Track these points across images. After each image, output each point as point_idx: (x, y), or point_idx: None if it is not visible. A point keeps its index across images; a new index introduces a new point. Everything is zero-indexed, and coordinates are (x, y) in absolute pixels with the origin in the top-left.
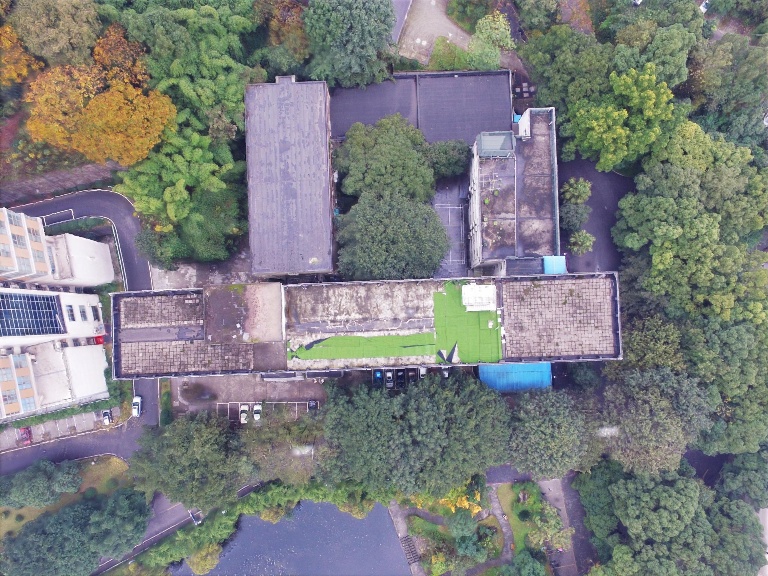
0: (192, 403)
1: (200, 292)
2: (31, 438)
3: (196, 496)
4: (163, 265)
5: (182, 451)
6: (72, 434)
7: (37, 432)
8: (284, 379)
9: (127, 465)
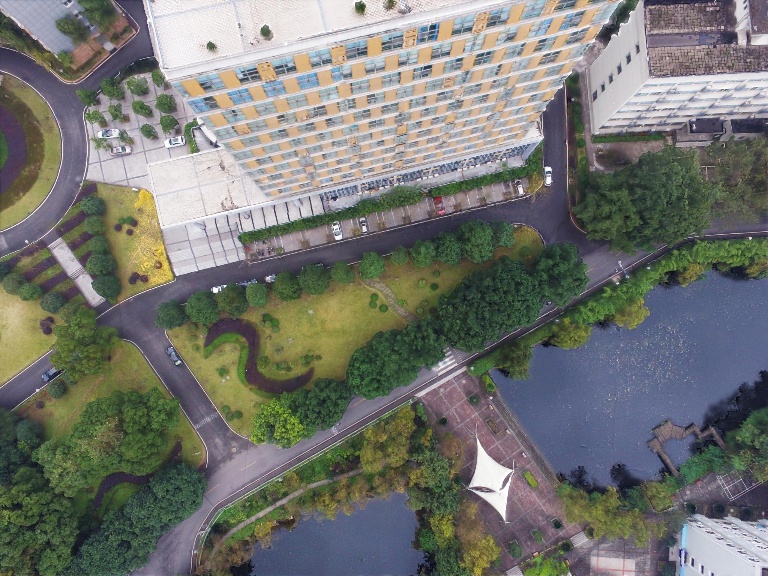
0: (608, 168)
1: (719, 1)
2: (444, 208)
3: (687, 214)
4: (615, 15)
5: (680, 167)
6: (482, 205)
7: (448, 203)
8: (694, 144)
9: (537, 234)
